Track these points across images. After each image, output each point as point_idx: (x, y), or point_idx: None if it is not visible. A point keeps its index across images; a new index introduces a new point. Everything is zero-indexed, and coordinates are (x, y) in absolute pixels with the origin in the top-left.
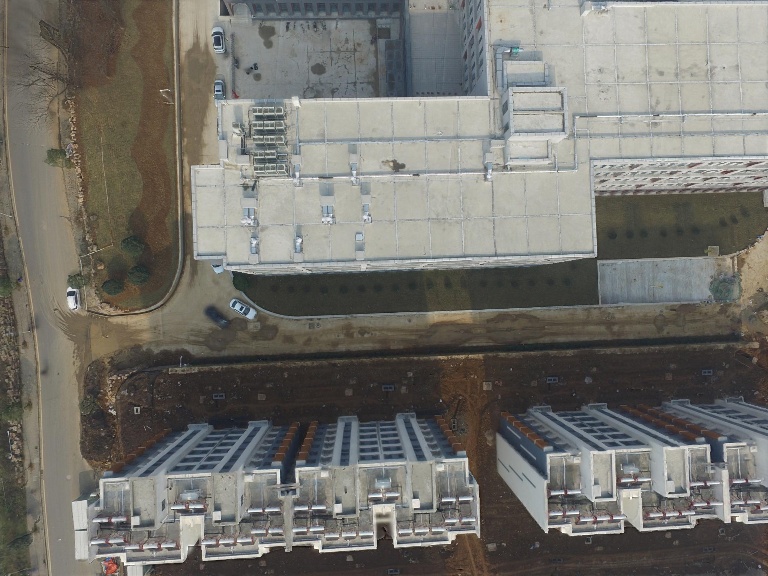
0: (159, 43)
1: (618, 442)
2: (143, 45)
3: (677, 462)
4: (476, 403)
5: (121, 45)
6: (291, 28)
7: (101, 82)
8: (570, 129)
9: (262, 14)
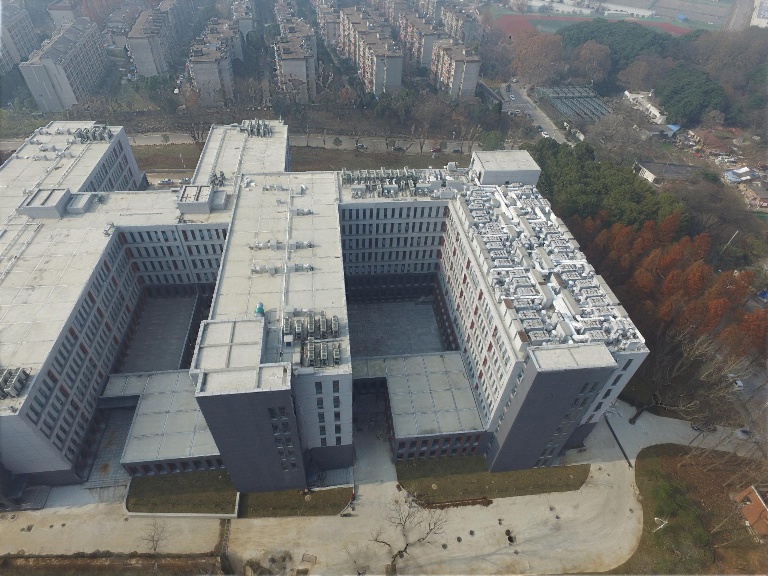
0: None
1: None
2: None
3: None
4: None
5: None
6: None
7: None
8: None
9: None
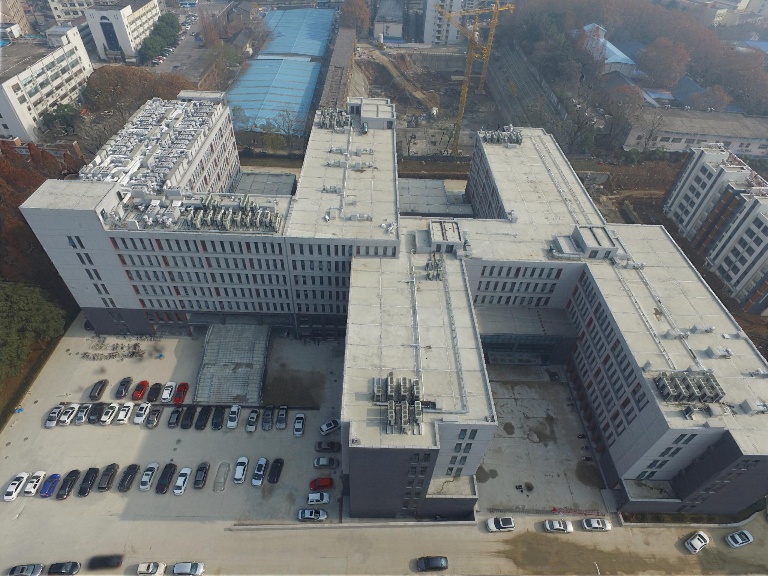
0: None
1: (761, 229)
2: None
3: (765, 201)
4: (747, 327)
5: None
6: None
7: None
8: None
9: None
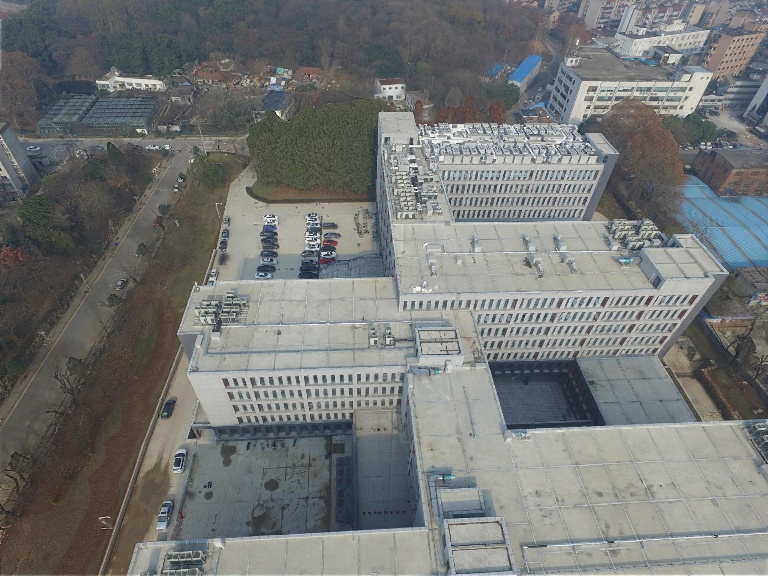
0: (121, 466)
1: None
2: (104, 469)
3: None
4: None
5: (82, 470)
6: (252, 447)
7: (45, 509)
8: (521, 562)
9: (227, 436)
